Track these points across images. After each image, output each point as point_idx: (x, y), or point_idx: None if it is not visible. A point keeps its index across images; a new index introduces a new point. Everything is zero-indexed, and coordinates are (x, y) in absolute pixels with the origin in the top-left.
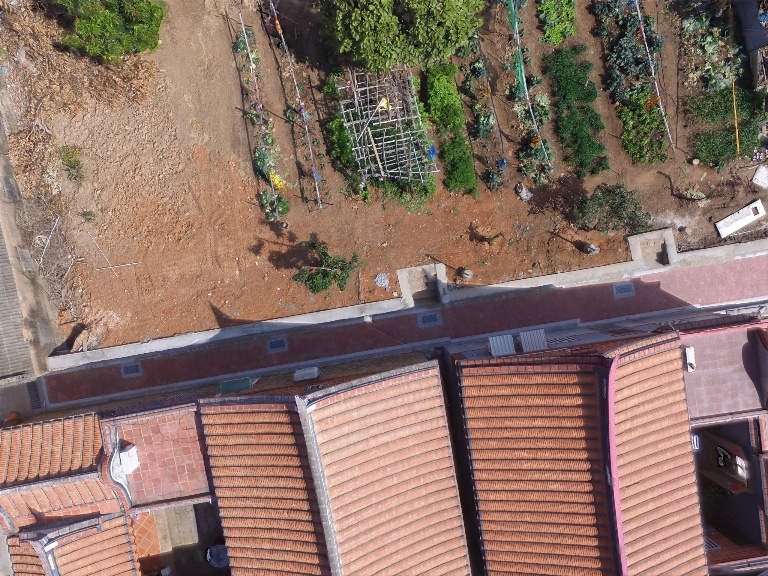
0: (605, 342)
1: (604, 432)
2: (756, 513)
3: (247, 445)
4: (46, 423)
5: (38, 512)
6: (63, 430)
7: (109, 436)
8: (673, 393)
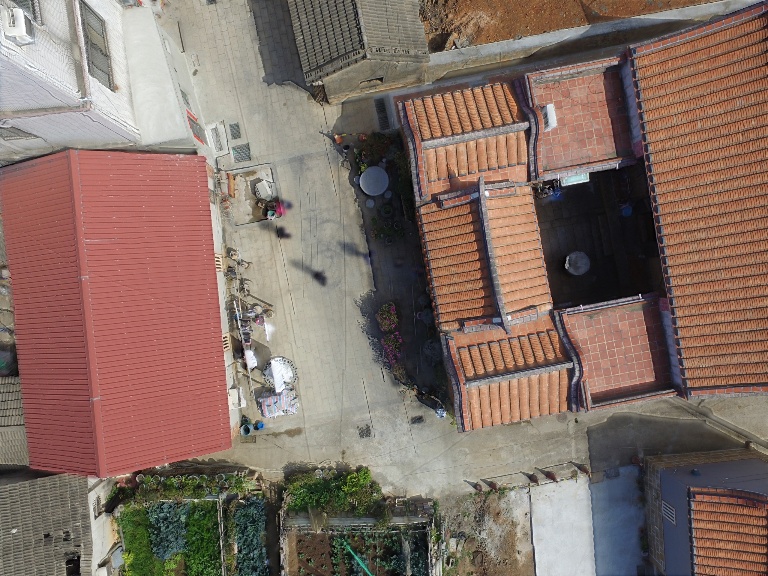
0: None
1: None
2: None
3: (693, 75)
4: (456, 91)
5: (455, 175)
6: (474, 97)
7: (534, 89)
8: None
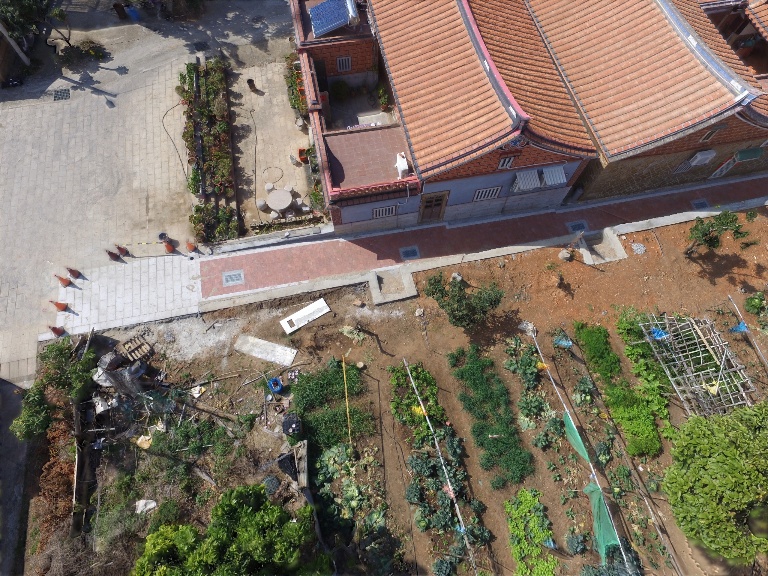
0: (474, 175)
1: None
2: None
3: None
4: None
5: None
6: None
7: None
8: (422, 133)
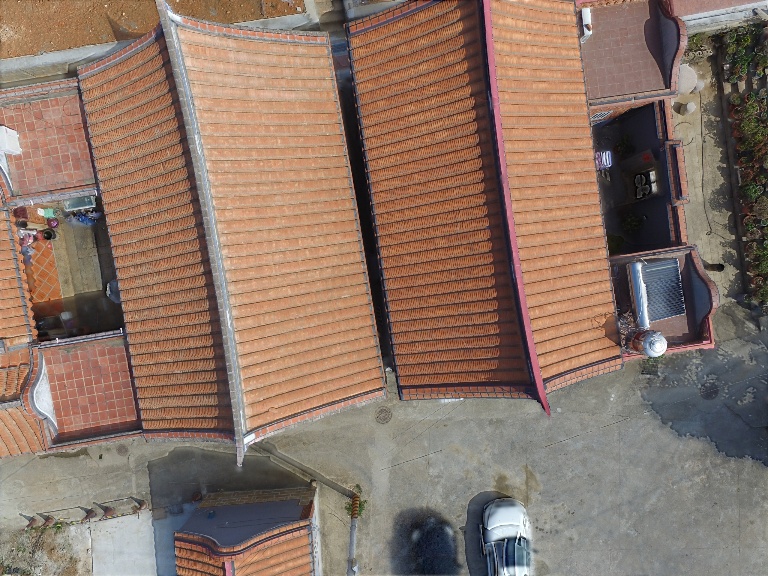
0: None
1: (484, 51)
2: (665, 211)
3: (123, 100)
4: None
5: None
6: None
7: None
8: (567, 49)
